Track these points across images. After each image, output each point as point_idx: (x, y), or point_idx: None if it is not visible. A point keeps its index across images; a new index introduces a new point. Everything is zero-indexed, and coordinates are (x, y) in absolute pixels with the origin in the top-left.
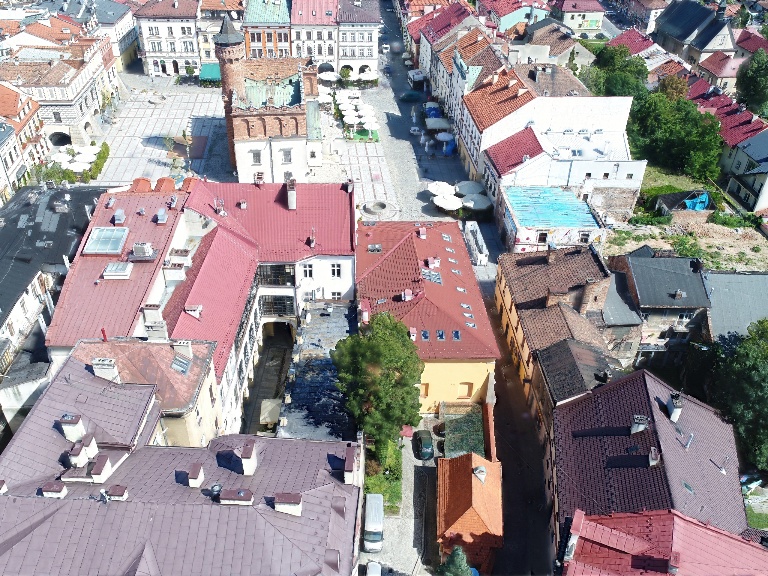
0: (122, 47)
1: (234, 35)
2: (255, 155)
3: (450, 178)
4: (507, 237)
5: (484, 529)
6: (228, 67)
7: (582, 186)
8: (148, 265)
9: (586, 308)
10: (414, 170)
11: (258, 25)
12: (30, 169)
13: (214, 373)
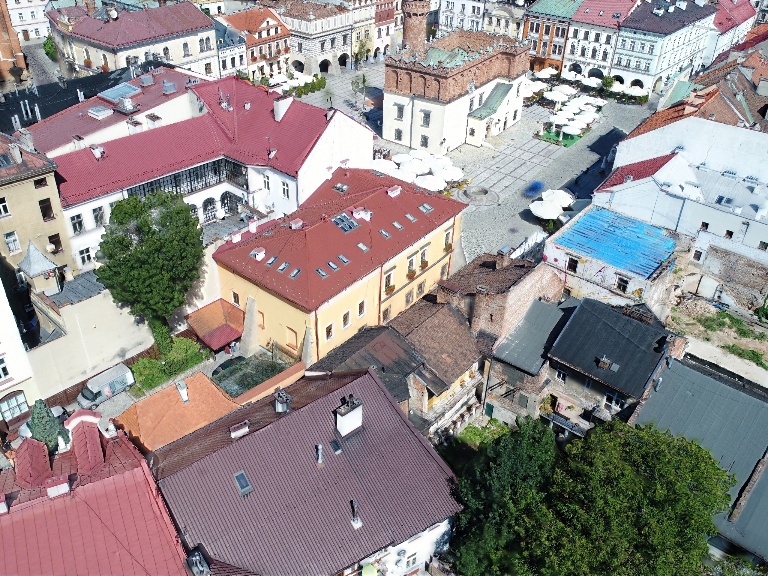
0: (431, 19)
1: None
2: (400, 110)
3: None
4: None
5: (138, 433)
6: (407, 21)
7: (694, 238)
8: (122, 116)
9: (478, 324)
10: (566, 179)
11: (539, 15)
12: (255, 80)
13: (58, 194)
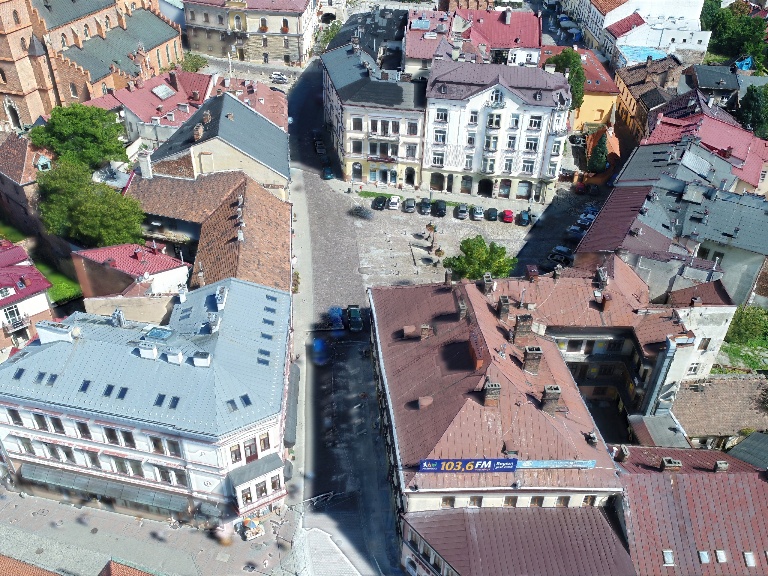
0: None
1: None
2: None
3: None
4: None
5: (612, 151)
6: None
7: (668, 48)
8: None
9: (668, 85)
10: None
11: None
12: None
13: None
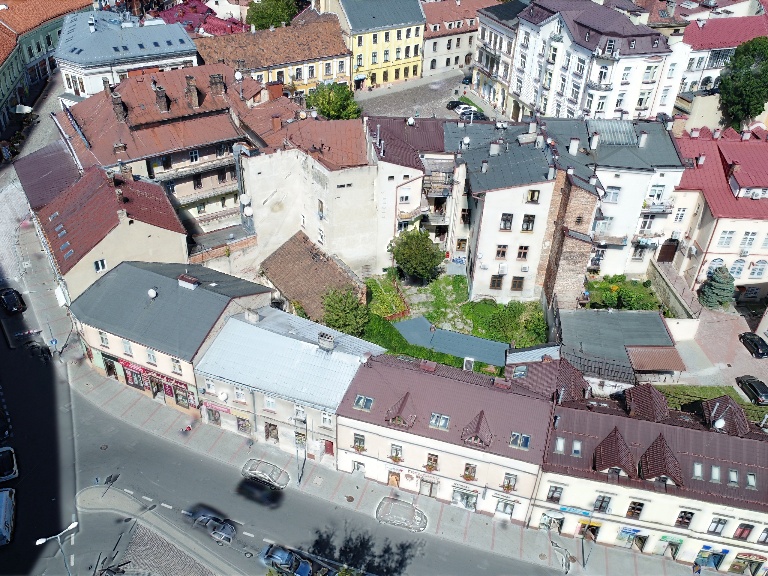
0: None
1: None
2: None
3: None
4: None
5: None
6: None
7: None
8: None
9: None
10: None
11: None
12: None
13: None
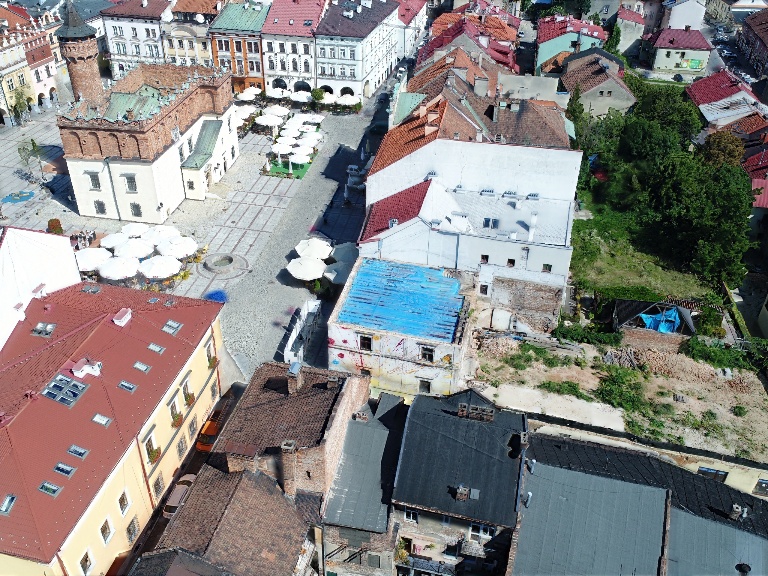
0: None
1: (77, 28)
2: (93, 178)
3: (350, 235)
4: None
5: None
6: (72, 67)
7: (477, 272)
8: None
9: (293, 487)
10: (313, 219)
11: (225, 31)
12: None
13: None
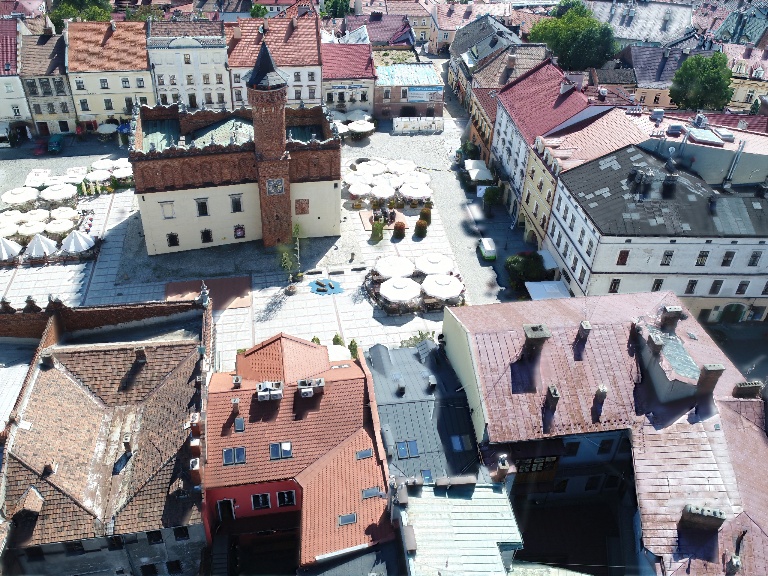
0: None
1: None
2: None
3: None
4: (421, 107)
5: None
6: None
7: None
8: None
9: None
10: None
11: None
12: None
13: None
